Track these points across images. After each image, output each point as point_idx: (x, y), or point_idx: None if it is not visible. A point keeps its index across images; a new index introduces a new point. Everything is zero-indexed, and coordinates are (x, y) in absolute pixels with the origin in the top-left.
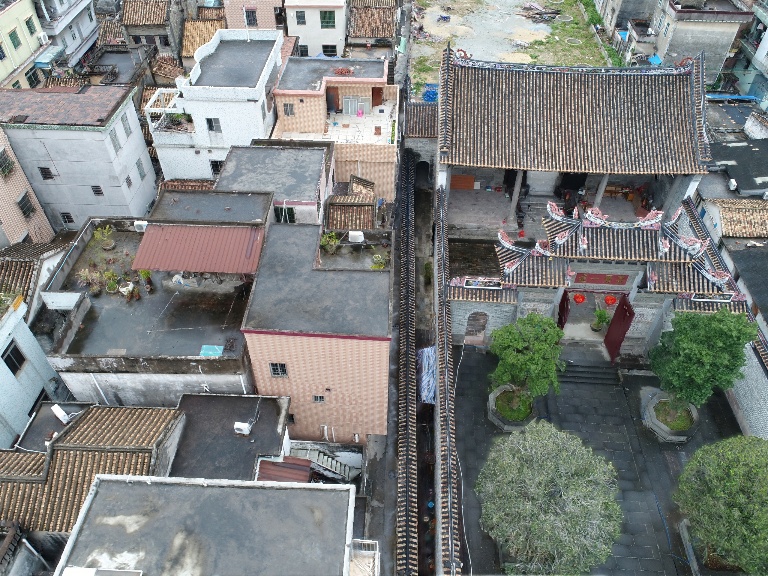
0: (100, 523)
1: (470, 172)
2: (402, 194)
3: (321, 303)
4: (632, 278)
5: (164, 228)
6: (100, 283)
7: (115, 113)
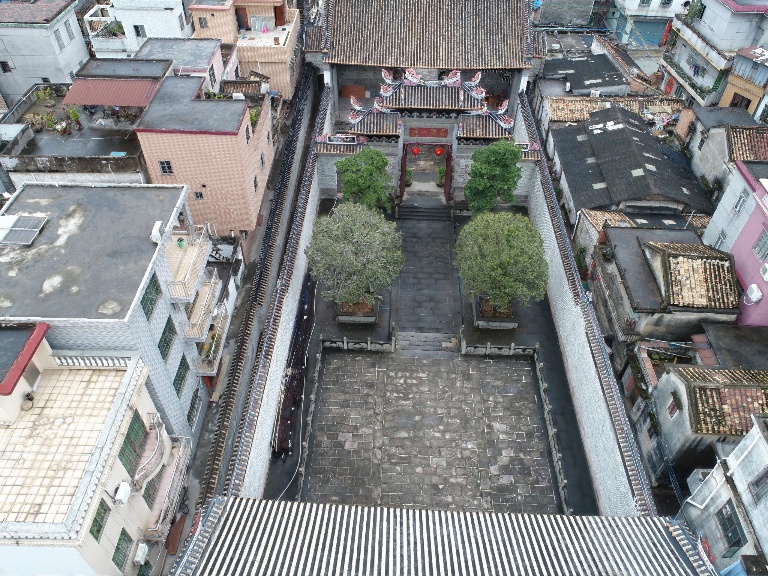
0: (24, 201)
1: (361, 82)
2: (299, 94)
3: (193, 116)
4: (451, 131)
5: (88, 80)
6: (42, 124)
7: (58, 16)
